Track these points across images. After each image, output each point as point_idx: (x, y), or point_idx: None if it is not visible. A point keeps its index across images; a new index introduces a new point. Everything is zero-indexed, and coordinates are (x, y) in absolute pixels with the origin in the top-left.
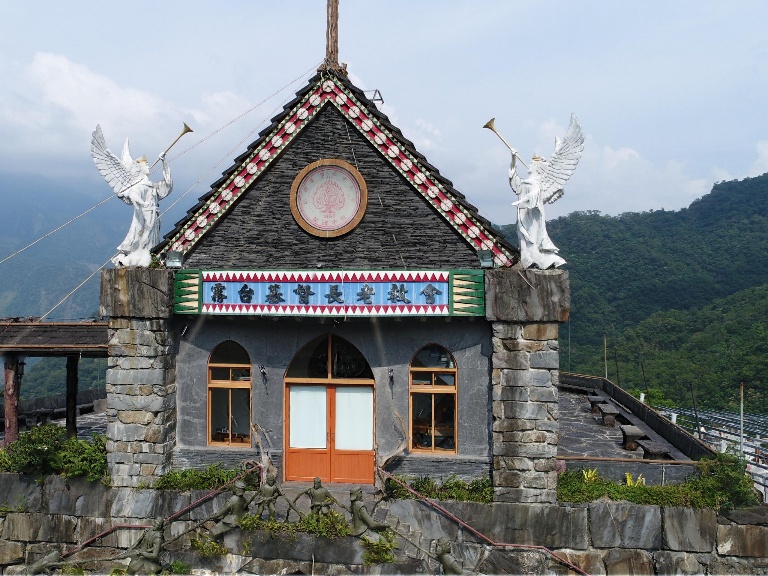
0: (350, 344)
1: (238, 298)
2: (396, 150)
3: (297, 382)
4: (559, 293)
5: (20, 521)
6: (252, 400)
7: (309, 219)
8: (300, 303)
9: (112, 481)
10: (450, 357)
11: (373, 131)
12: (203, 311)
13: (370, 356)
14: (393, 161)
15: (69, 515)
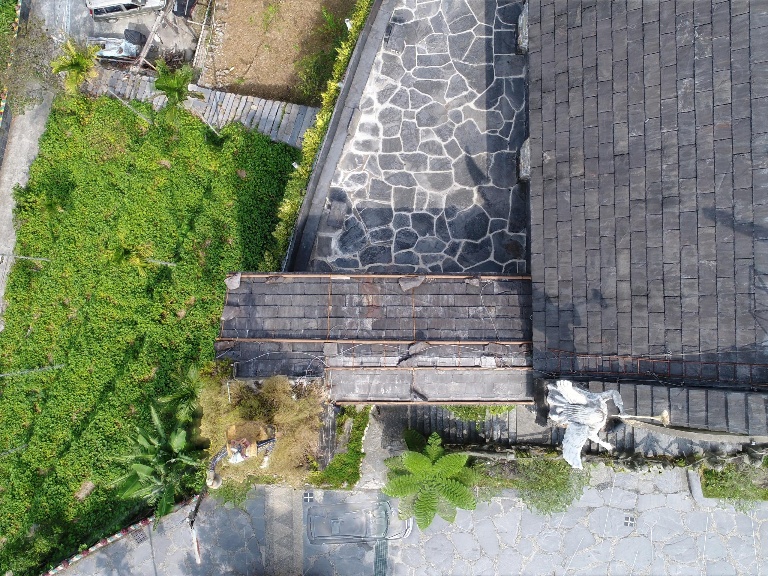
0: None
1: None
2: None
3: None
4: None
5: None
6: None
7: None
8: None
9: None
10: None
11: None
12: None
13: None
14: None
15: None
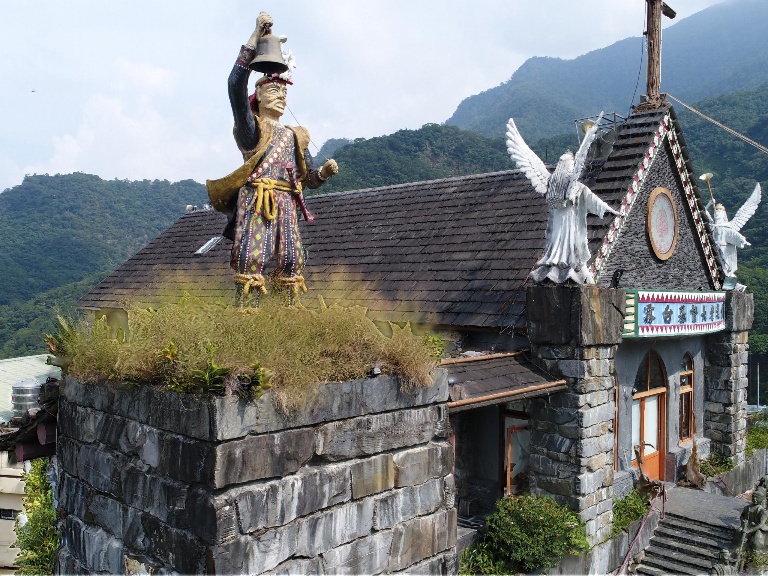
0: (657, 357)
1: (662, 319)
2: (689, 188)
3: (636, 398)
4: (750, 309)
5: None
6: None
7: None
8: (693, 322)
9: None
10: (687, 362)
11: None
12: (640, 334)
13: None
14: (687, 197)
15: None
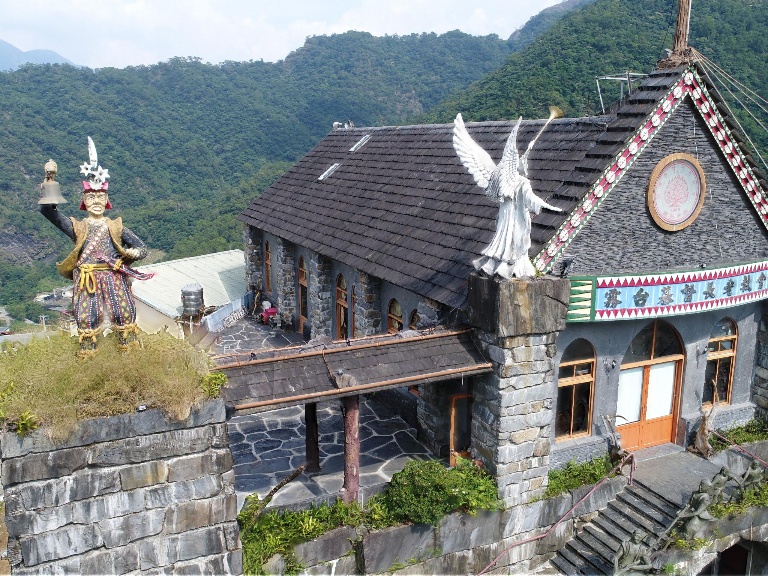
0: (669, 326)
1: (633, 302)
2: (731, 146)
3: (629, 368)
4: None
5: (414, 574)
6: (596, 392)
7: (661, 213)
8: (685, 302)
9: (504, 504)
10: (731, 326)
11: (718, 127)
12: (597, 318)
13: (685, 335)
14: (727, 157)
15: (462, 551)
